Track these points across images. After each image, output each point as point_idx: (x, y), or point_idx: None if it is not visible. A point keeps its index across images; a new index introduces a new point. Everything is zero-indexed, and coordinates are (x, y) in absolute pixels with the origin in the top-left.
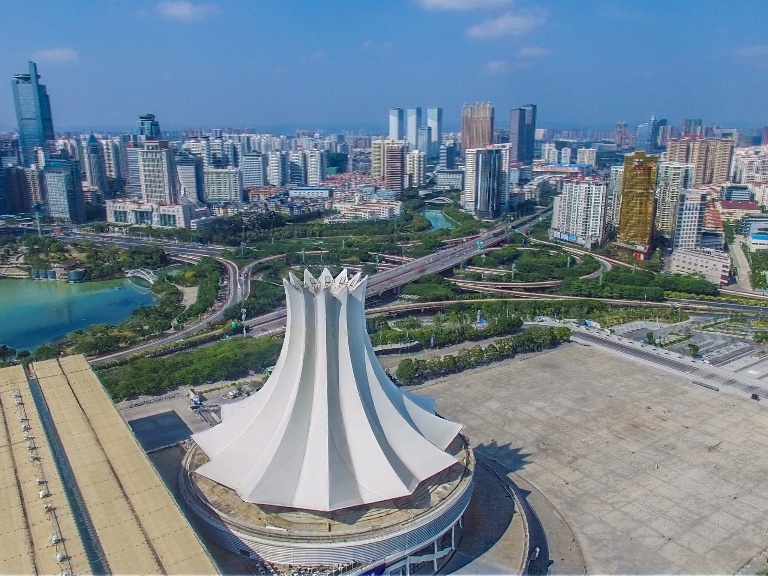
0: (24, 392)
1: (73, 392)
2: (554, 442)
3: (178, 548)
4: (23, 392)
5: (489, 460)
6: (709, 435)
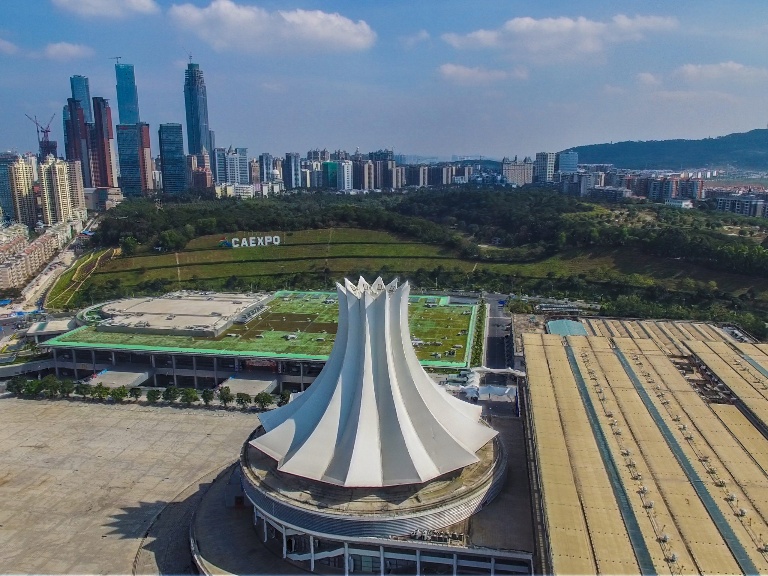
0: (665, 568)
1: (591, 538)
2: (82, 506)
3: (541, 380)
4: (667, 569)
5: (160, 519)
6: (8, 452)
